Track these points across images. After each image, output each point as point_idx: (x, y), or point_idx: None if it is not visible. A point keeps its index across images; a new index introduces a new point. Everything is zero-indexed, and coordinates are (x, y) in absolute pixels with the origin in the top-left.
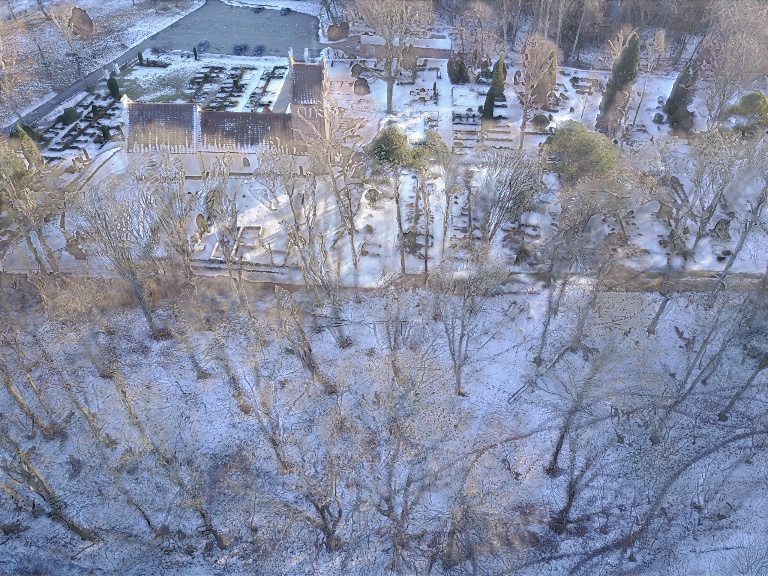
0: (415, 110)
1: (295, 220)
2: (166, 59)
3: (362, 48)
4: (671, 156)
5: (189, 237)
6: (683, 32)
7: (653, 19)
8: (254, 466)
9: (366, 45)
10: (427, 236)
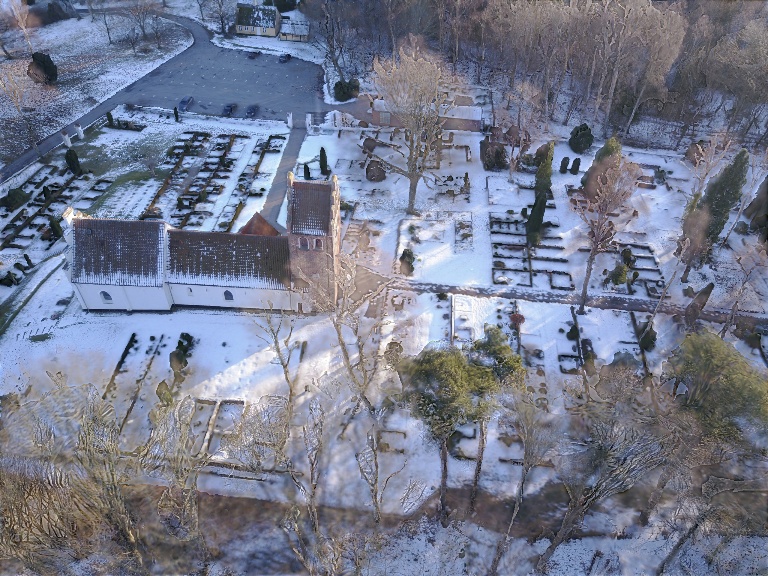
0: (442, 208)
1: (291, 391)
2: (141, 119)
3: (375, 115)
4: None
5: (146, 413)
6: (754, 106)
7: (712, 83)
8: None
9: (380, 112)
10: (479, 465)
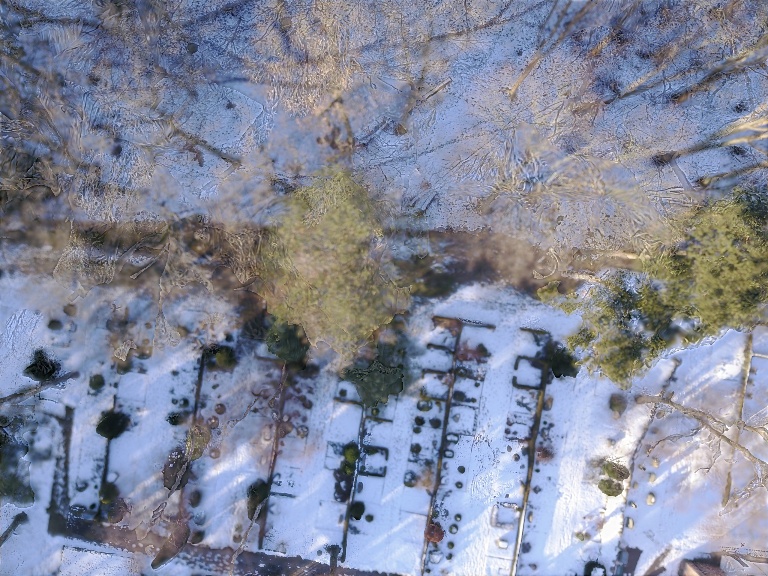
0: None
1: None
2: None
3: None
4: (180, 225)
5: None
6: None
7: None
8: (760, 17)
9: None
10: None
